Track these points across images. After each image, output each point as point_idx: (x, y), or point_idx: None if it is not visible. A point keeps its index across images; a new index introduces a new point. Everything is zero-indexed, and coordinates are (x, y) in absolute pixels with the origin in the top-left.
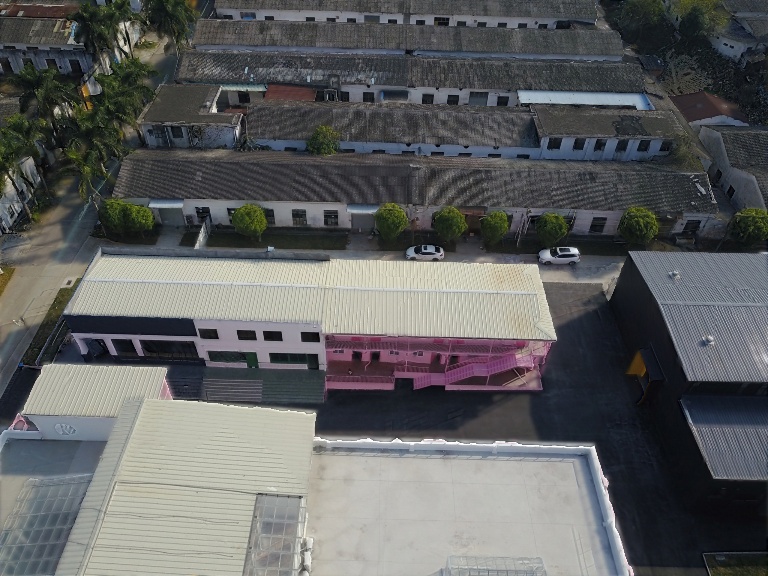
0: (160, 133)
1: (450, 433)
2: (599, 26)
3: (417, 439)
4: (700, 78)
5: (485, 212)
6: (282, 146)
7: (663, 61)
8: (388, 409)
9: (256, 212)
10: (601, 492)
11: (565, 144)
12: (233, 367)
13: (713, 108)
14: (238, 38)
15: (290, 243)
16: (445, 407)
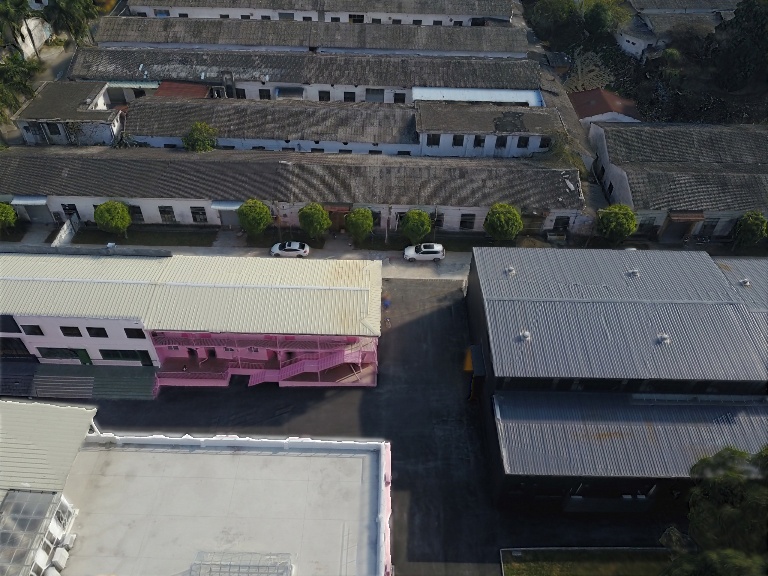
0: (37, 130)
1: (274, 429)
2: (515, 23)
3: (239, 435)
4: (603, 75)
5: (350, 208)
6: (161, 143)
7: (571, 58)
8: (217, 406)
9: (117, 209)
10: (380, 488)
11: (444, 140)
12: (67, 364)
13: (605, 105)
14: (141, 35)
15: (157, 240)
16: (275, 403)
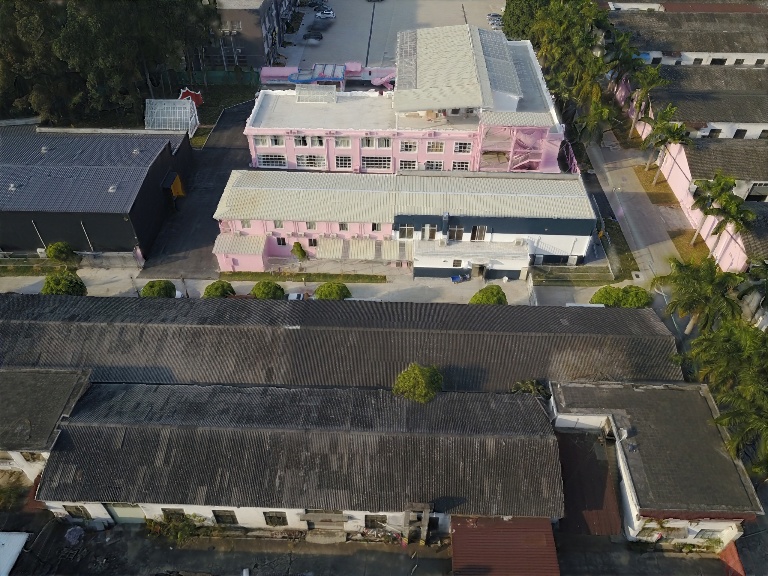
0: None
1: None
2: None
3: None
4: None
5: None
6: None
7: None
8: None
9: None
10: None
11: None
12: None
13: None
14: None
15: None
16: None
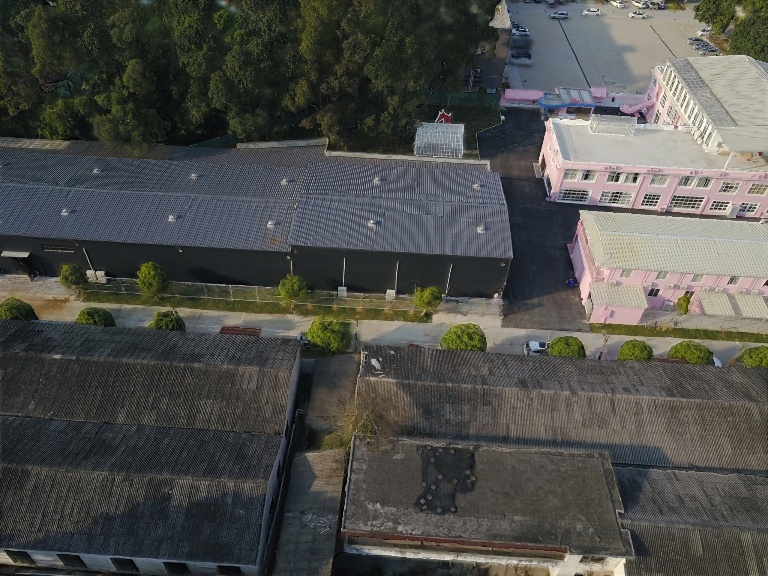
0: None
1: None
2: None
3: None
4: None
5: (654, 361)
6: None
7: None
8: None
9: None
10: None
11: None
12: None
13: None
14: None
15: None
16: None
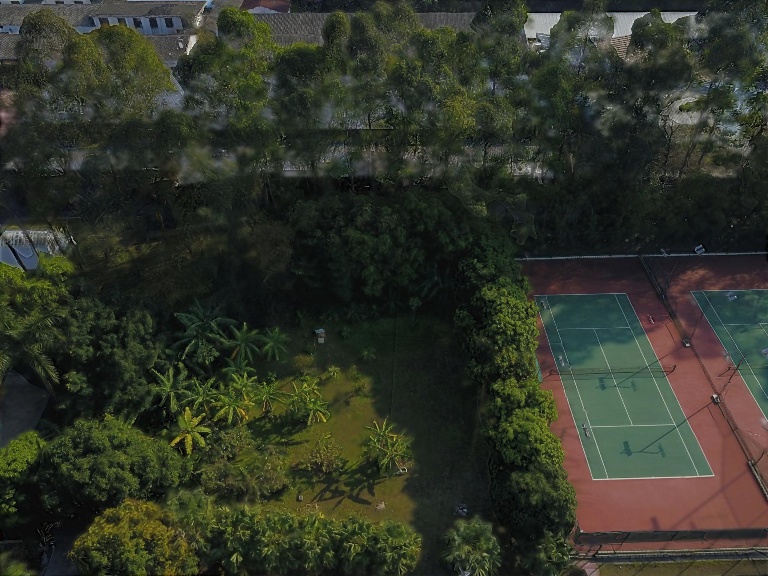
0: None
1: None
2: None
3: None
4: None
5: None
6: None
7: None
8: None
9: None
10: None
11: (112, 23)
12: None
13: (258, 2)
14: None
15: None
16: None
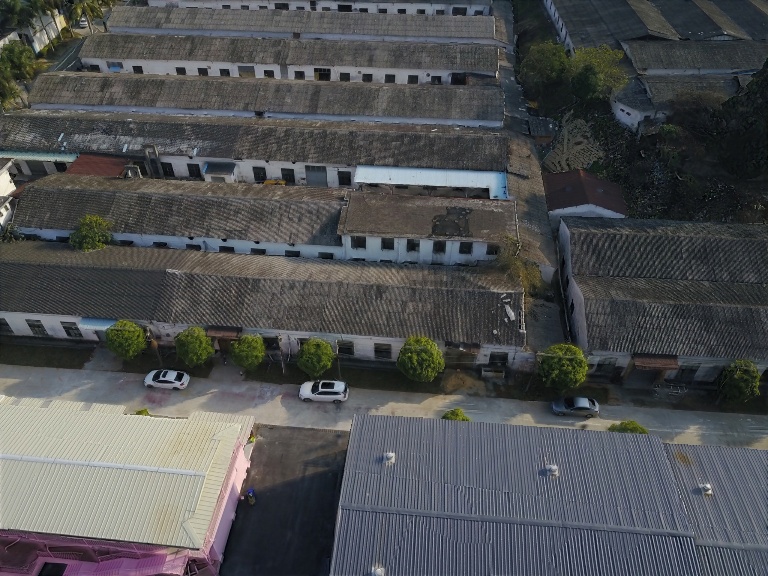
0: None
1: None
2: (501, 79)
3: None
4: (591, 149)
5: (238, 334)
6: (53, 235)
7: (558, 125)
8: None
9: None
10: None
11: (371, 243)
12: None
13: (581, 194)
14: (75, 96)
15: (23, 357)
16: None
